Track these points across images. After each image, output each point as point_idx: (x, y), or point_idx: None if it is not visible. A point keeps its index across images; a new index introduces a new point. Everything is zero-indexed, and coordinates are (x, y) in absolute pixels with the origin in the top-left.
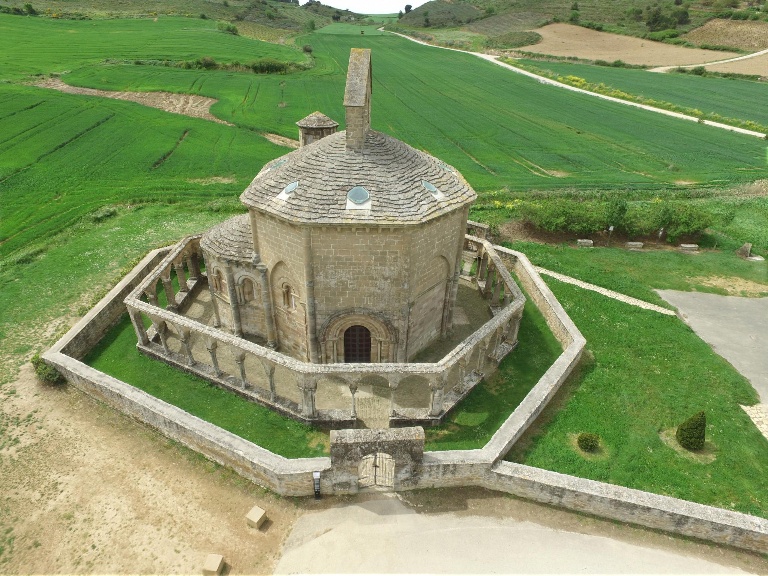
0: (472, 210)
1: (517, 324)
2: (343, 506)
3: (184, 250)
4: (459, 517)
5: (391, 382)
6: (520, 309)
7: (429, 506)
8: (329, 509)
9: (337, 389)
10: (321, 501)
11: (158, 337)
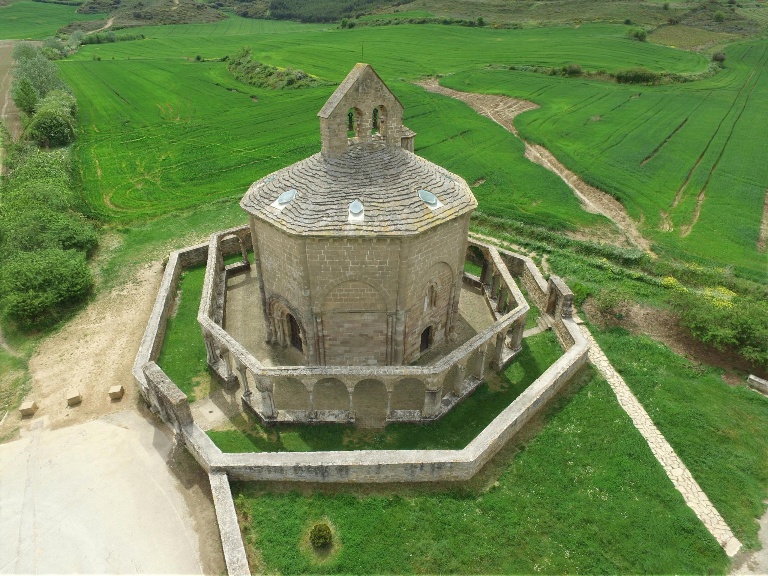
0: (625, 276)
1: (428, 396)
2: (150, 423)
3: None
4: (176, 488)
5: (236, 362)
6: (427, 379)
7: (177, 465)
8: (144, 418)
9: (263, 359)
10: (148, 411)
11: (236, 270)
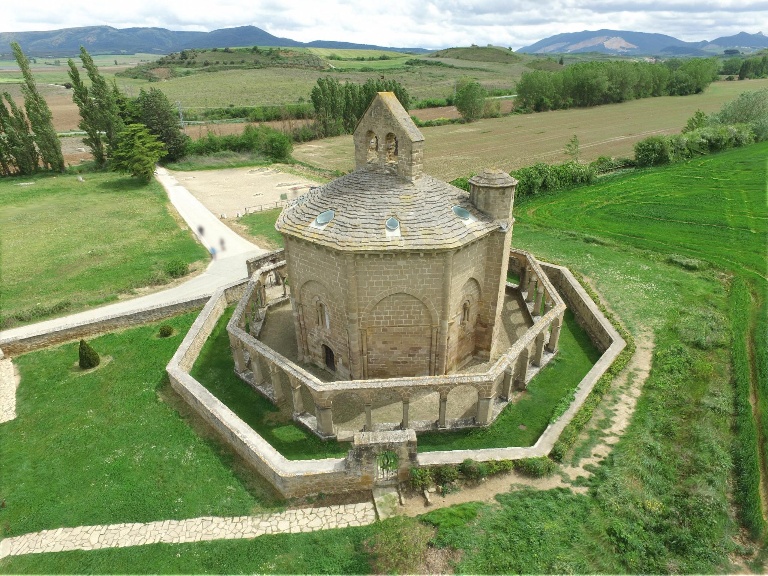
0: None
1: None
2: None
3: (514, 255)
4: None
5: None
6: None
7: None
8: None
9: None
10: None
11: None
